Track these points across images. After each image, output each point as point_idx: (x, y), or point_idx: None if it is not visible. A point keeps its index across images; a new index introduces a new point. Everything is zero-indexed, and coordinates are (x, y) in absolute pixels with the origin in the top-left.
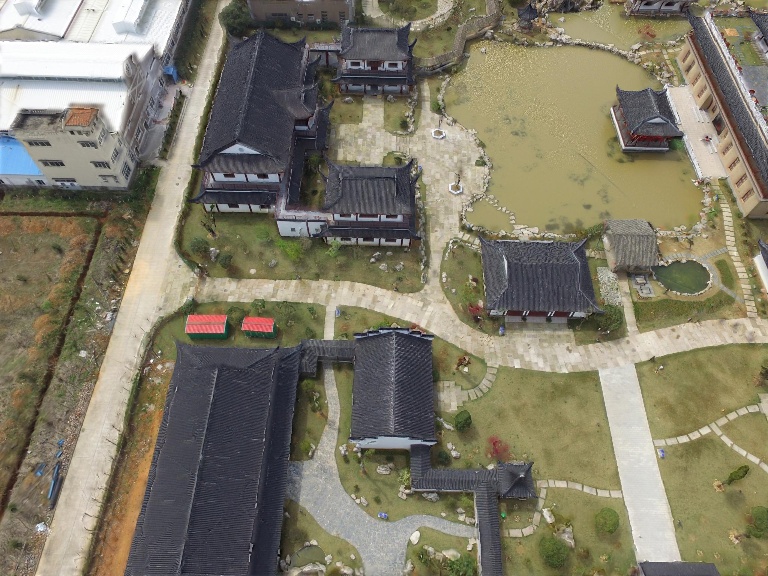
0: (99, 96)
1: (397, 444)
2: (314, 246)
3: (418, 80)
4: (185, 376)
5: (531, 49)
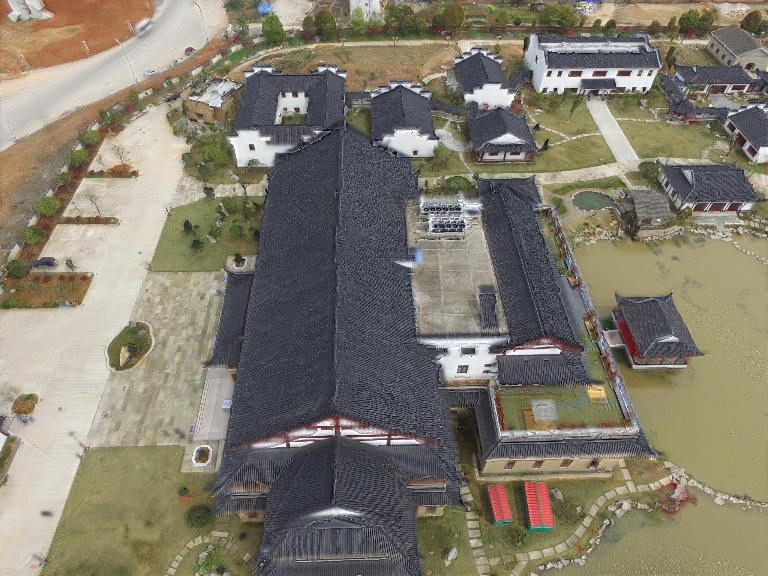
0: None
1: None
2: None
3: None
4: None
5: None
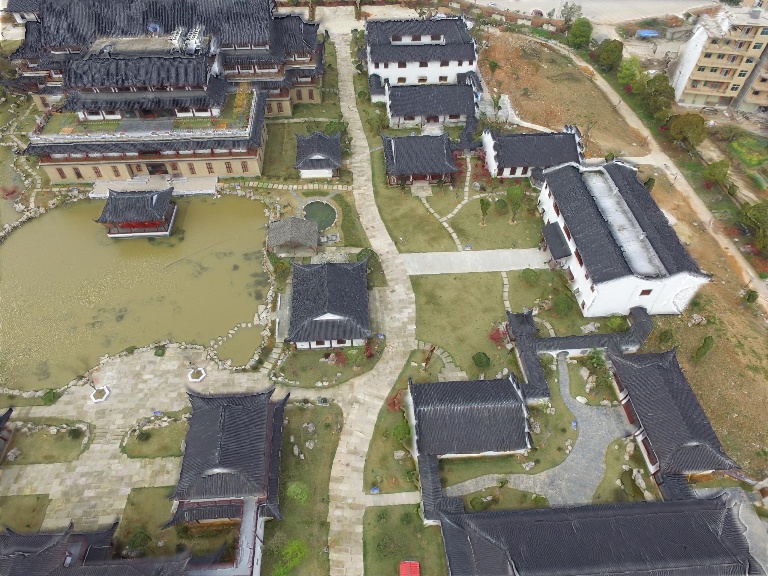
0: None
1: None
2: None
3: None
4: None
5: None
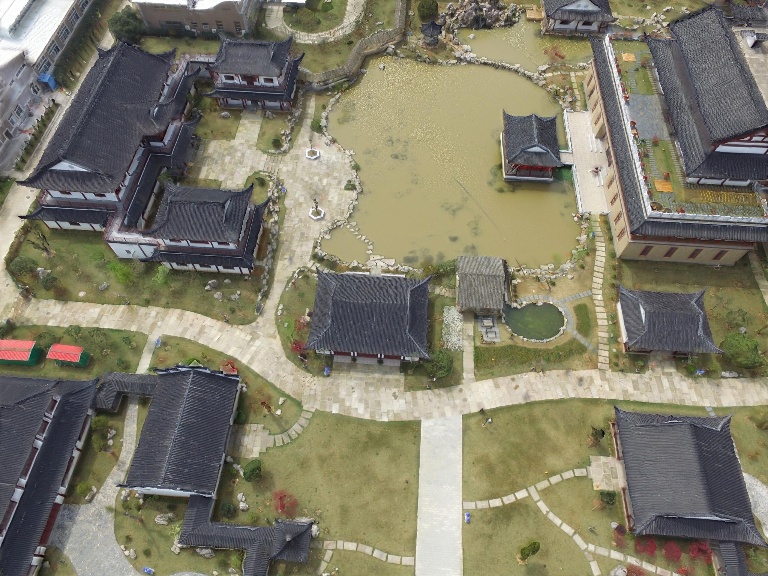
0: None
1: (178, 493)
2: (151, 270)
3: (305, 96)
4: None
5: (433, 67)
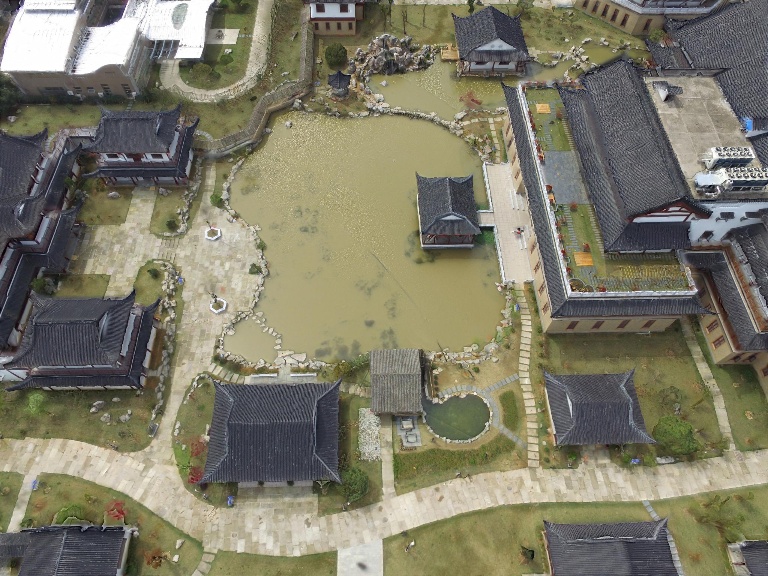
0: None
1: None
2: (28, 392)
3: (205, 164)
4: None
5: (344, 120)
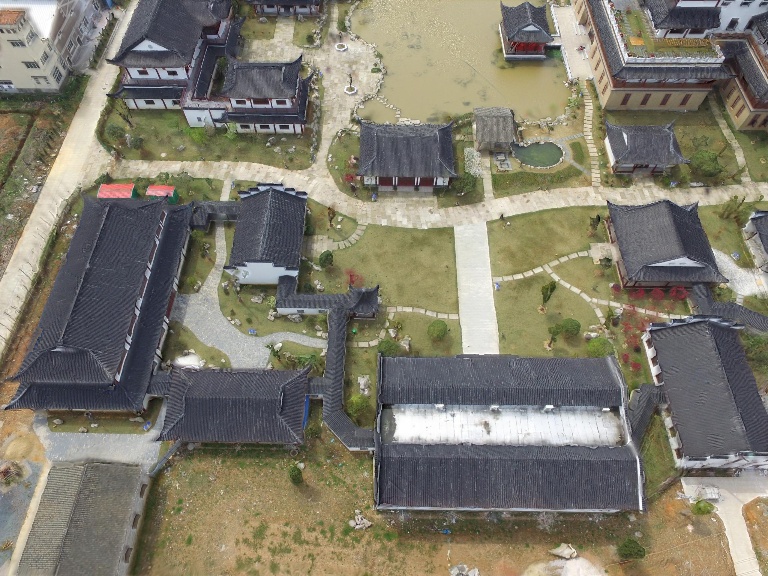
0: (32, 9)
1: (269, 277)
2: (219, 135)
3: (329, 4)
4: (85, 216)
5: None
